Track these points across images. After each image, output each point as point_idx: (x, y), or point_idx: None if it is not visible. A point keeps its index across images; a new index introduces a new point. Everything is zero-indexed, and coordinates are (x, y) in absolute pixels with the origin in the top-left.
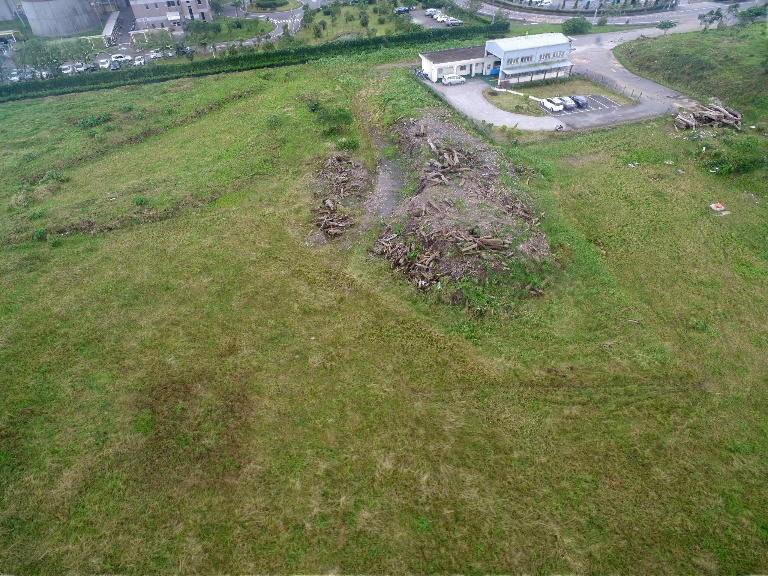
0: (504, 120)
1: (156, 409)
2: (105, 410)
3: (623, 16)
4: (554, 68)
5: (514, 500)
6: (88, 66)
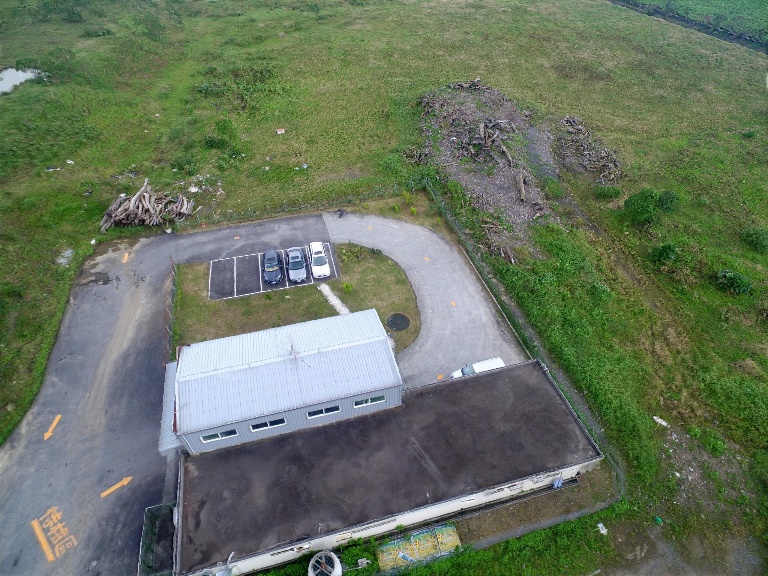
0: (405, 237)
1: None
2: None
3: None
4: None
5: None
6: None
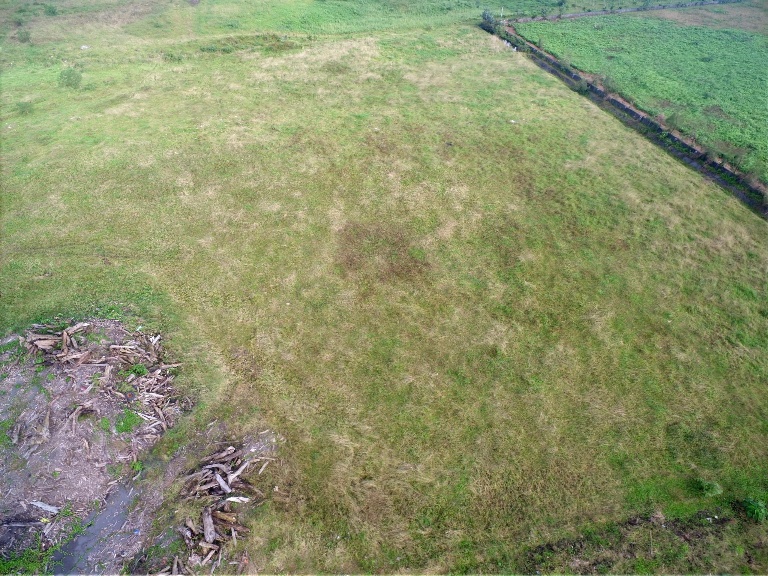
0: None
1: None
2: None
3: None
4: None
5: None
6: None
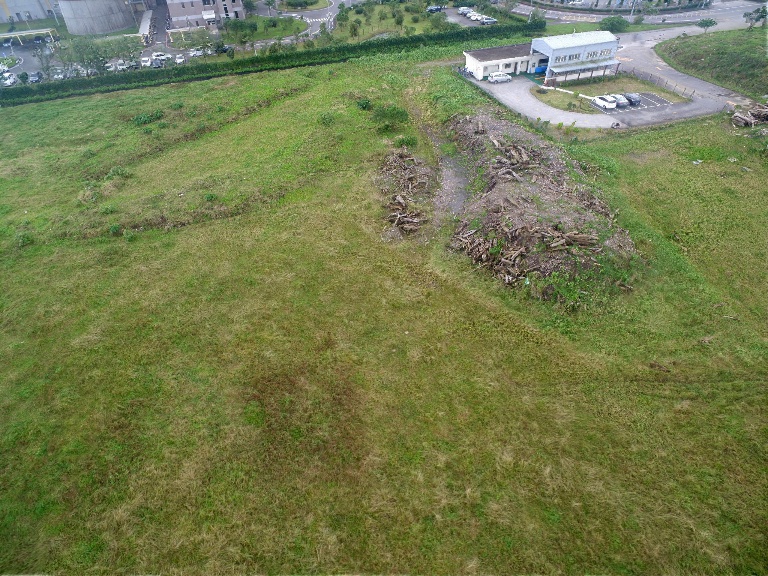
0: (558, 118)
1: (264, 401)
2: (212, 402)
3: (657, 15)
4: (601, 66)
5: (641, 493)
6: (130, 64)
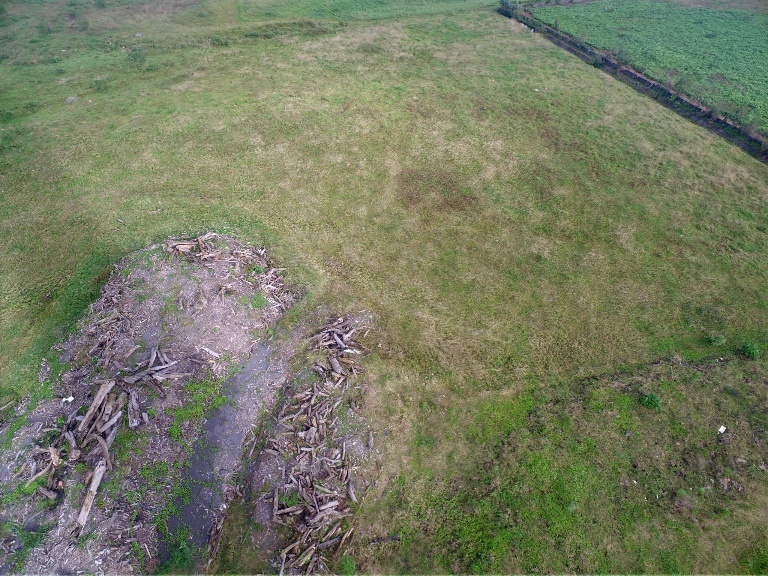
0: None
1: None
2: None
3: None
4: None
5: None
6: None
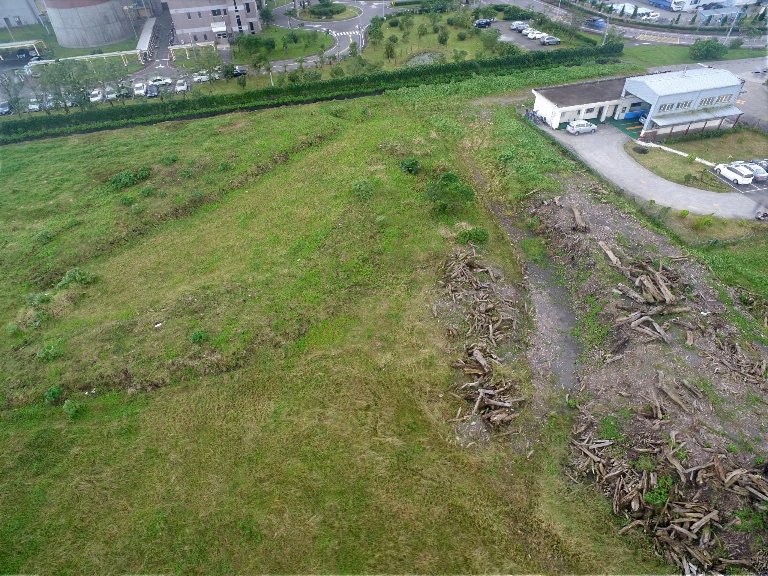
0: (675, 197)
1: None
2: None
3: None
4: (717, 116)
5: None
6: (121, 92)
